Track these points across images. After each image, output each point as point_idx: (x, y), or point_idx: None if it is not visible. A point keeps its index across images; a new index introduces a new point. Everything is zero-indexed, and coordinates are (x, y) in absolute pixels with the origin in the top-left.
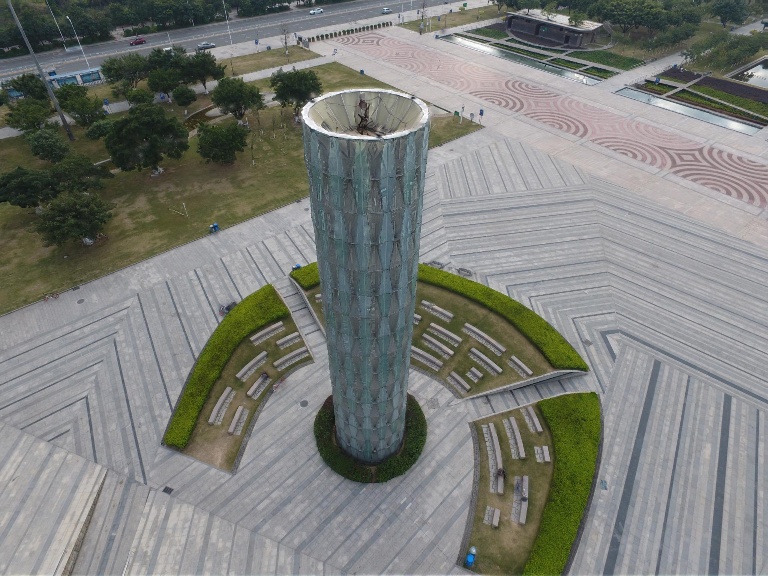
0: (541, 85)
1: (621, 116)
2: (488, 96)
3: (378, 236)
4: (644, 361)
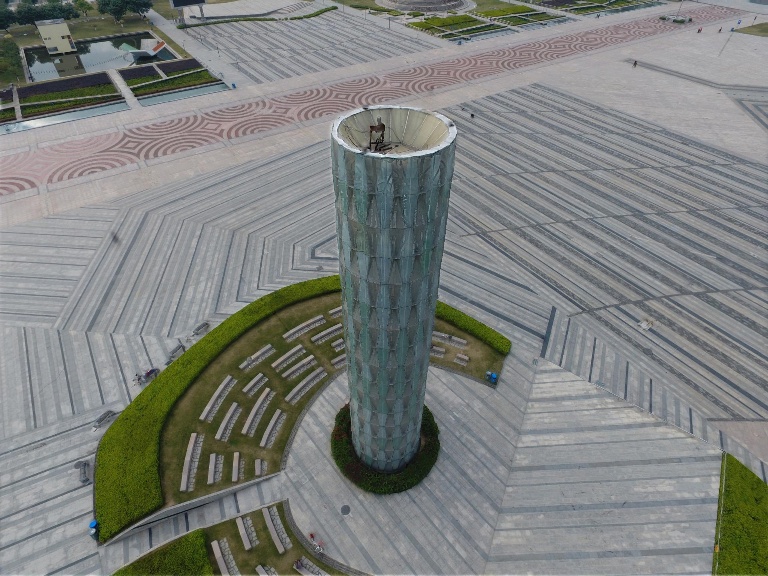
0: None
1: (24, 152)
2: None
3: None
4: None
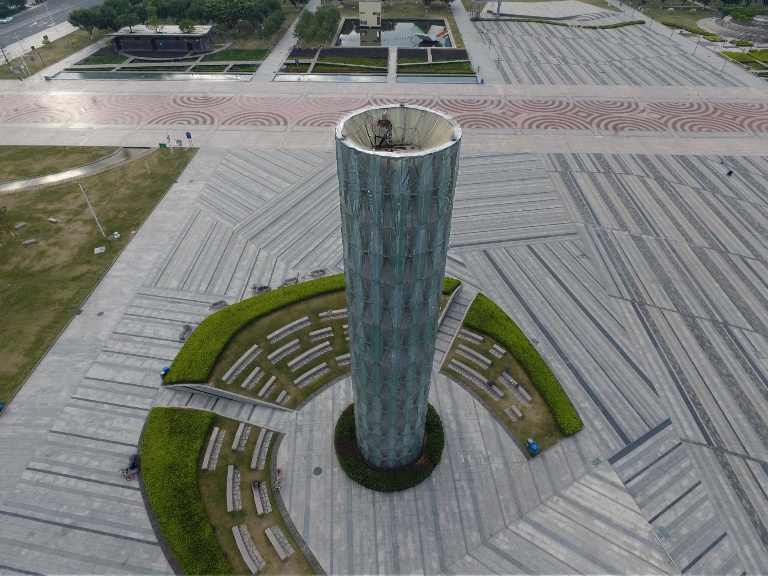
0: (208, 94)
1: (296, 98)
2: (171, 119)
3: (446, 232)
4: (478, 256)
